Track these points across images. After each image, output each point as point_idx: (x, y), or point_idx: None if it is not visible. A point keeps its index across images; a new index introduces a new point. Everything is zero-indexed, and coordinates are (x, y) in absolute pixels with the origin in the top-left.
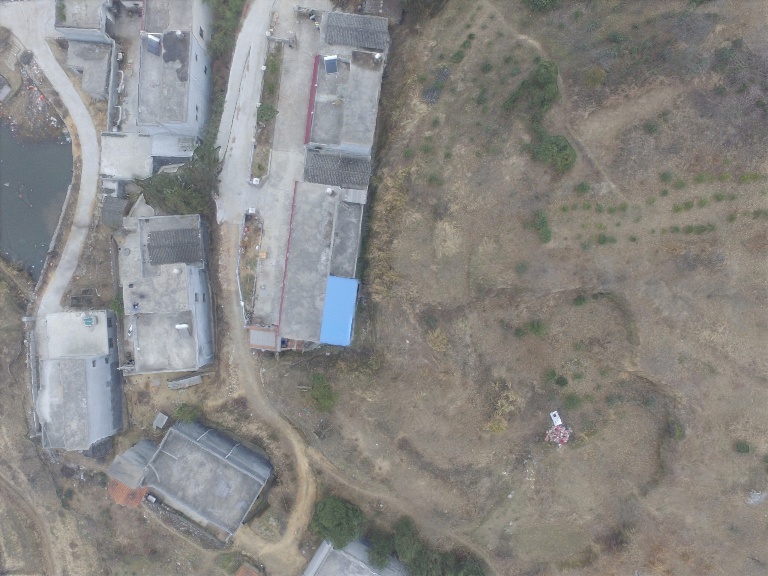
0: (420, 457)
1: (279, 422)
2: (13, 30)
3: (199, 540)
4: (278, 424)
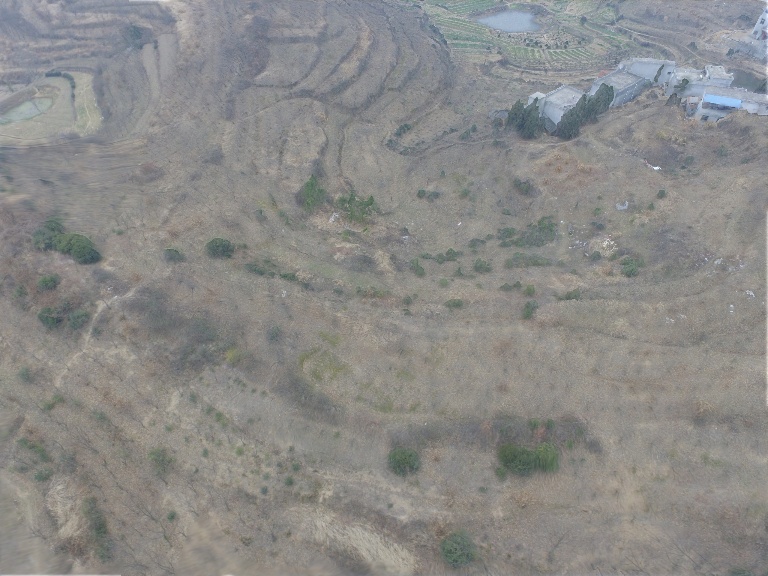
0: None
1: None
2: None
3: None
4: None
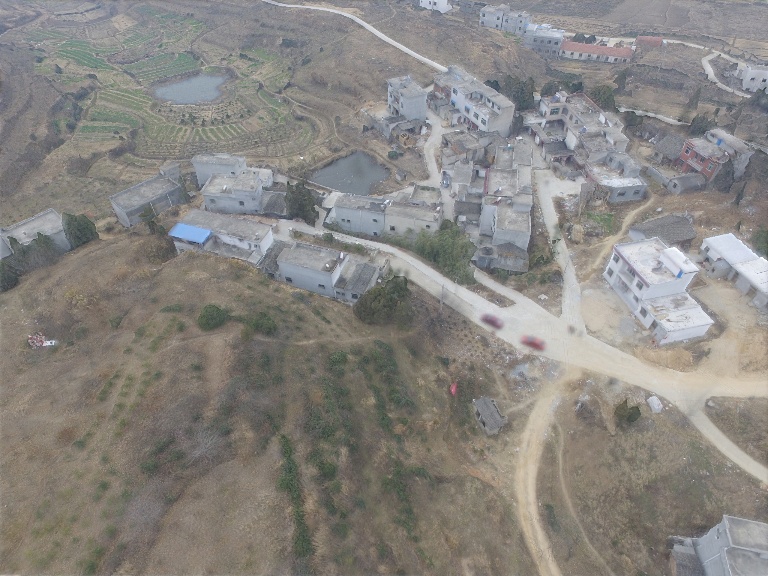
0: None
1: None
2: (427, 181)
3: None
4: None
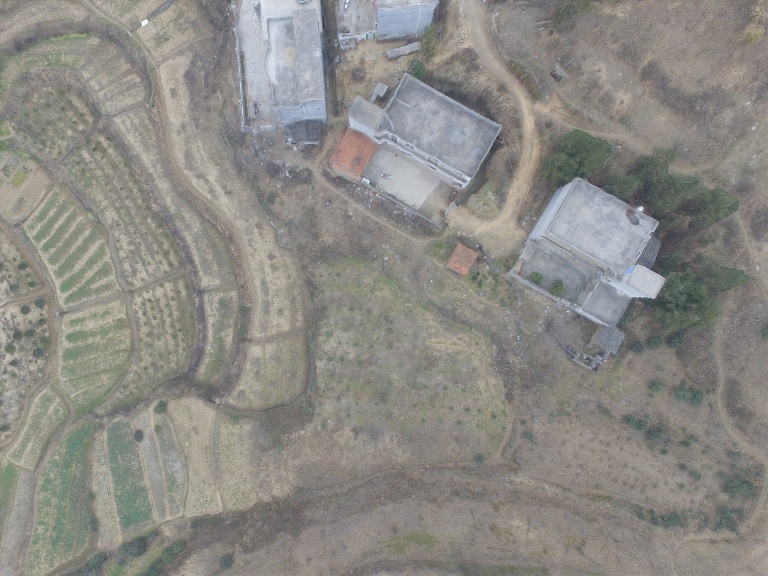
0: (667, 82)
1: (507, 77)
2: None
3: (409, 229)
4: (506, 79)
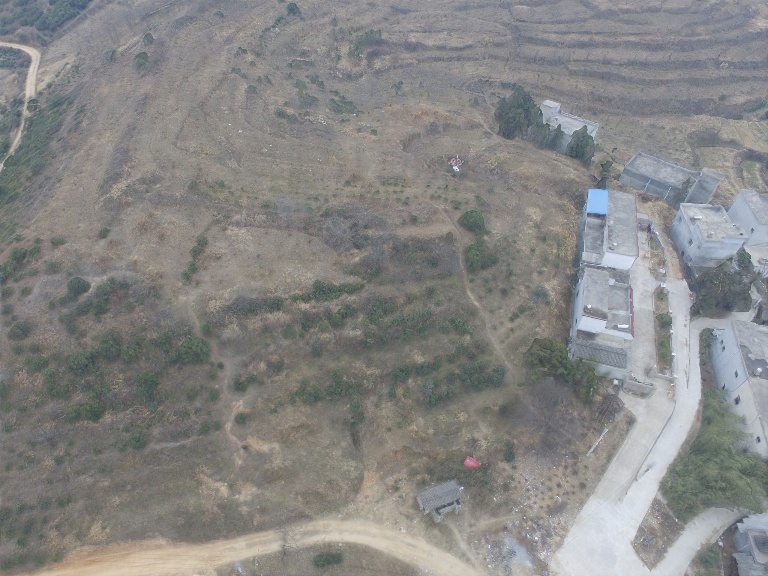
0: None
1: None
2: None
3: None
4: None
